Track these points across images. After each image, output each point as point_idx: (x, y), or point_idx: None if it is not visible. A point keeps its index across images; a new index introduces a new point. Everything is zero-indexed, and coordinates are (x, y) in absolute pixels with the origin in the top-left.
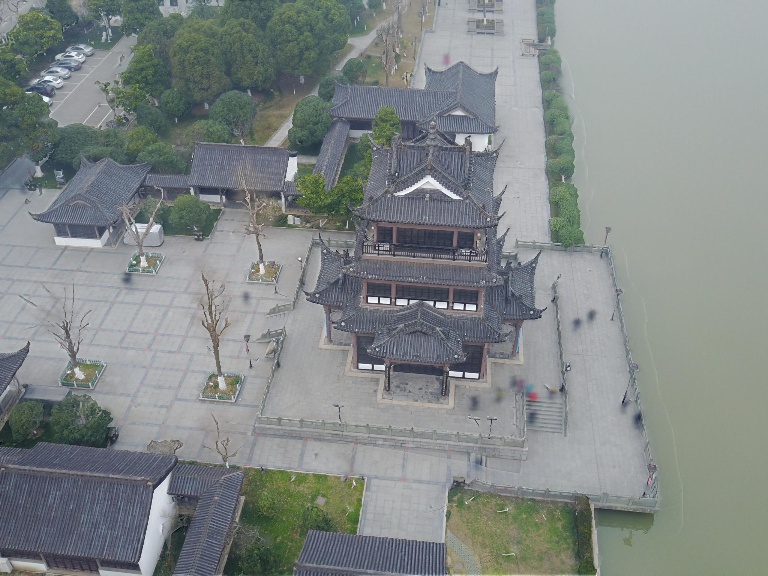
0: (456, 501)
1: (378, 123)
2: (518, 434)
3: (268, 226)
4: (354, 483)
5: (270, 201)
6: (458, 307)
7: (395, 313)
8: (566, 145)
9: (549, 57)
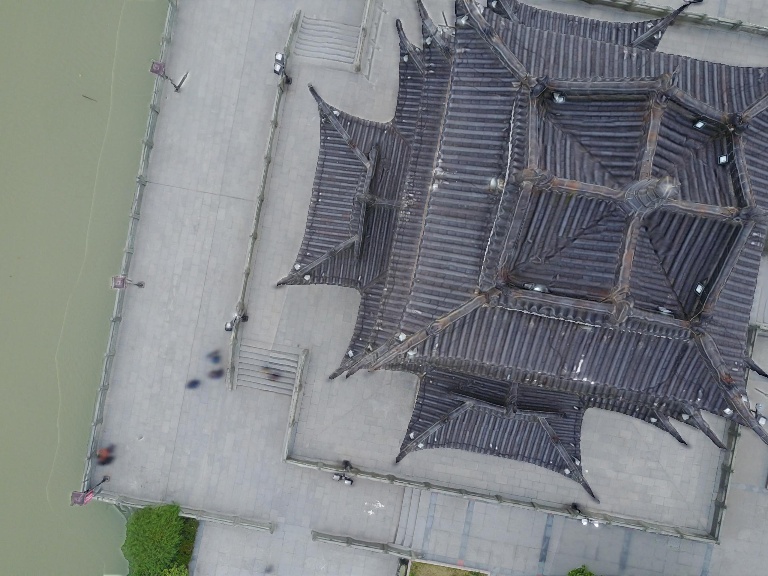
0: None
1: None
2: None
3: None
4: None
5: None
6: None
7: None
8: None
9: None
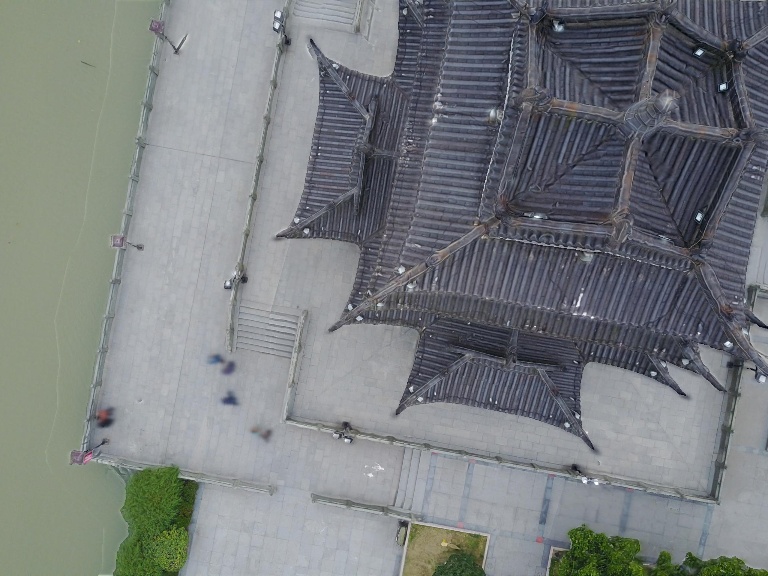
0: None
1: None
2: None
3: None
4: None
5: None
6: None
7: None
8: None
9: None
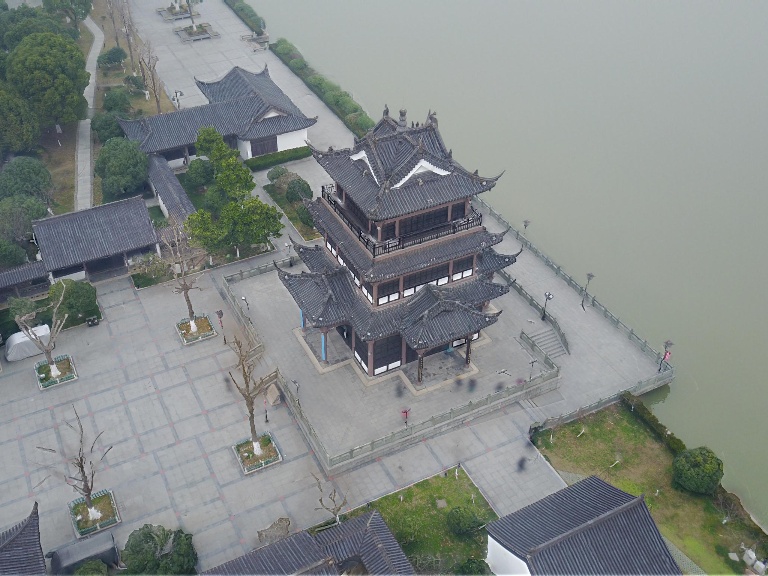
0: (542, 445)
1: (204, 146)
2: (544, 368)
3: (157, 284)
4: (456, 473)
5: (149, 257)
6: (457, 277)
7: (405, 305)
8: (368, 119)
9: (285, 47)
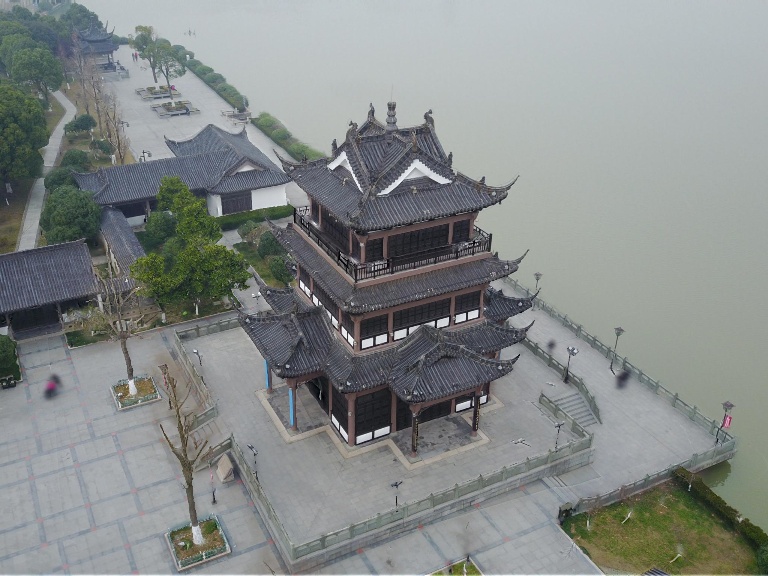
0: (577, 533)
1: (166, 196)
2: (572, 437)
3: (95, 342)
4: (464, 570)
5: (88, 310)
6: (460, 319)
7: (395, 351)
8: None
9: (268, 119)
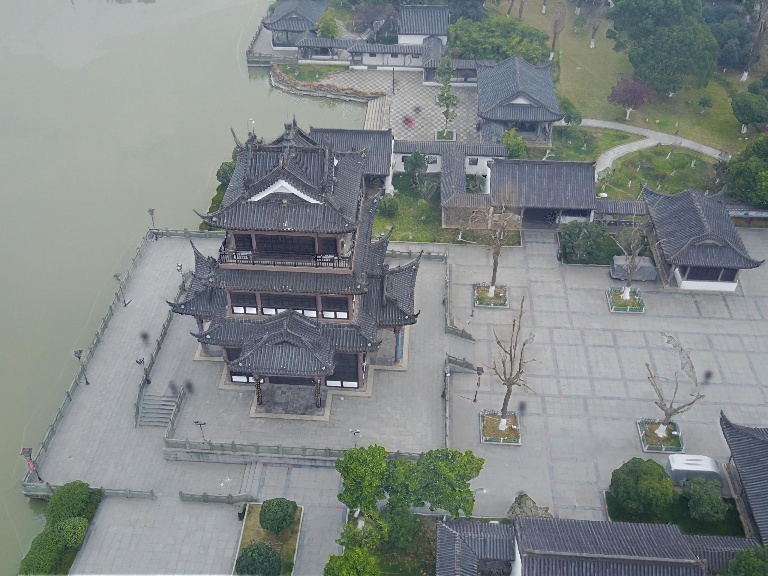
0: None
1: None
2: None
3: None
4: None
5: None
6: None
7: None
8: None
9: None
